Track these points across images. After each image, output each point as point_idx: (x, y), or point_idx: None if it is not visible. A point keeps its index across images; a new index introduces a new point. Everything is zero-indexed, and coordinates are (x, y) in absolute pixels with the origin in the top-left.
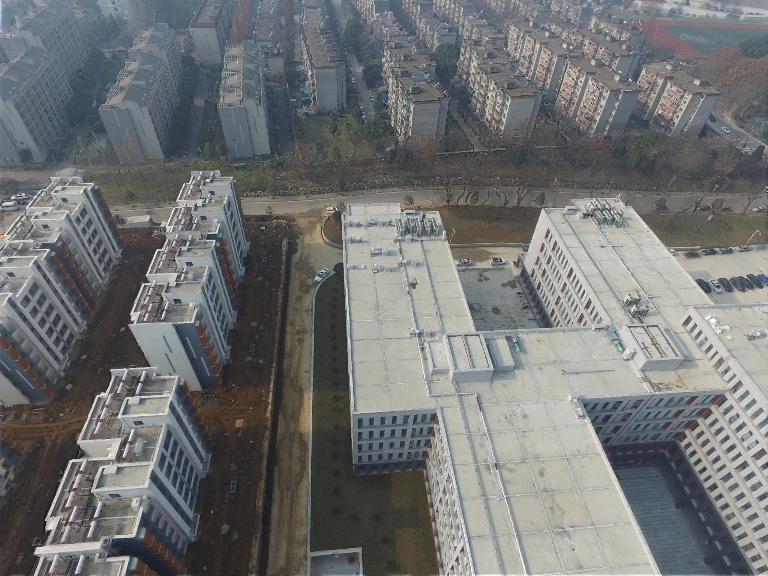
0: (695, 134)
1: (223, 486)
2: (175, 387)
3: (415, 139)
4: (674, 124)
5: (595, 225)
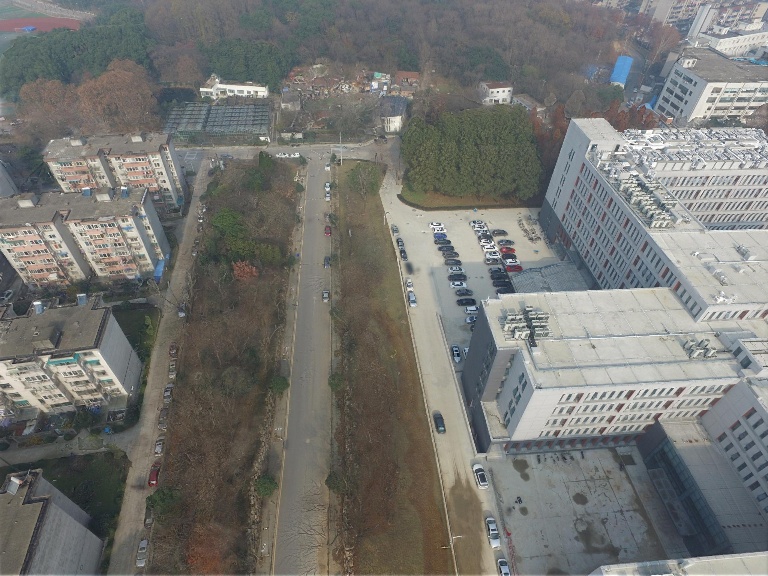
0: (184, 183)
1: None
2: None
3: None
4: (168, 190)
5: (553, 341)
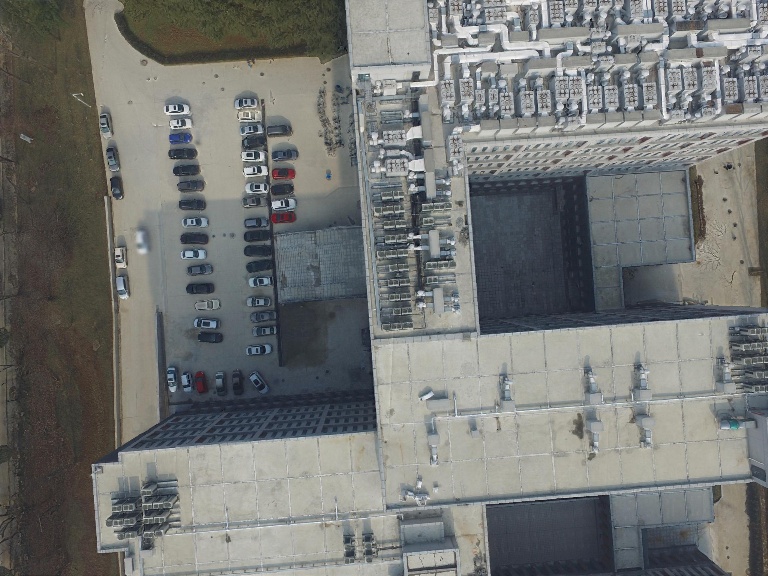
0: None
1: None
2: None
3: None
4: None
5: None
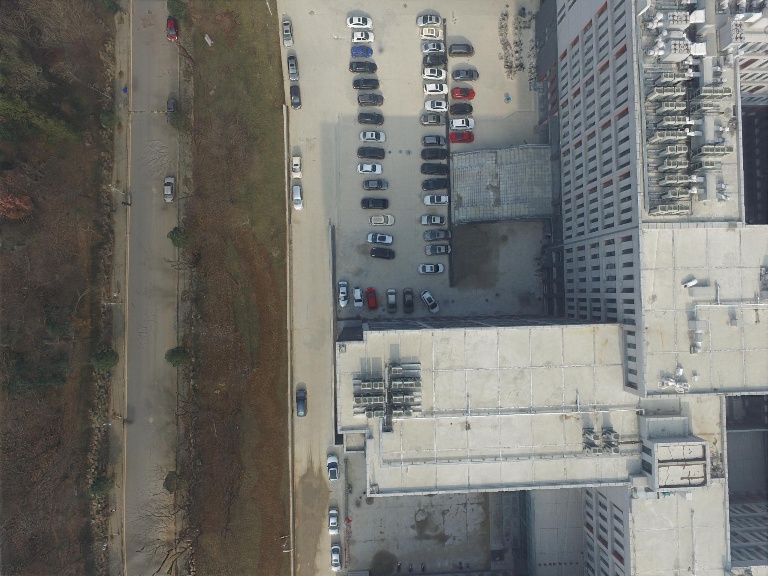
0: None
1: None
2: None
3: None
4: None
5: None
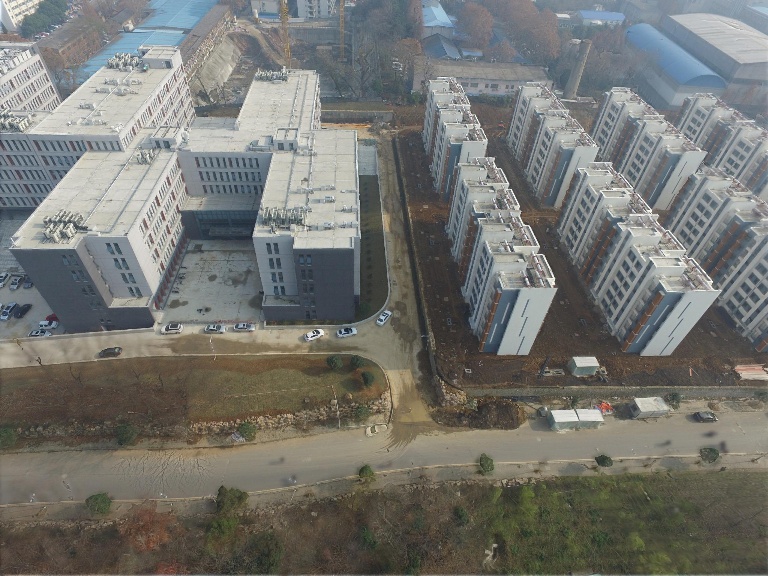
0: None
1: (425, 186)
2: (450, 140)
3: (169, 572)
4: None
5: None
